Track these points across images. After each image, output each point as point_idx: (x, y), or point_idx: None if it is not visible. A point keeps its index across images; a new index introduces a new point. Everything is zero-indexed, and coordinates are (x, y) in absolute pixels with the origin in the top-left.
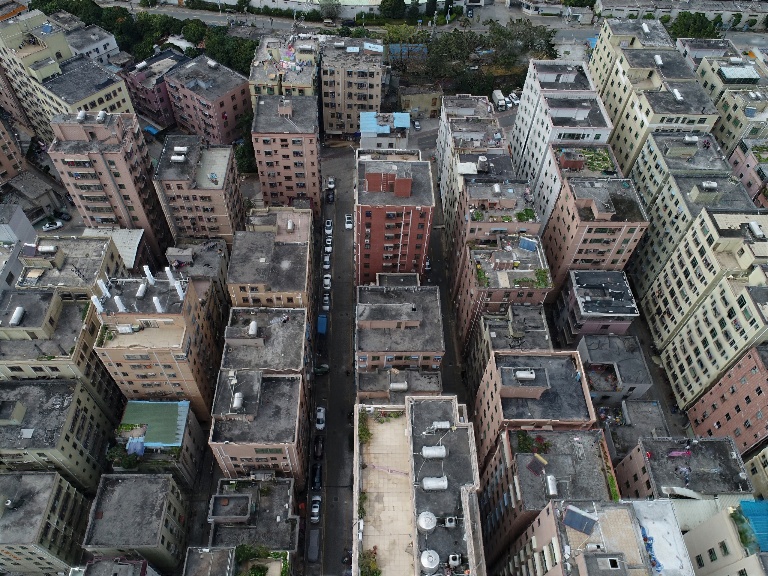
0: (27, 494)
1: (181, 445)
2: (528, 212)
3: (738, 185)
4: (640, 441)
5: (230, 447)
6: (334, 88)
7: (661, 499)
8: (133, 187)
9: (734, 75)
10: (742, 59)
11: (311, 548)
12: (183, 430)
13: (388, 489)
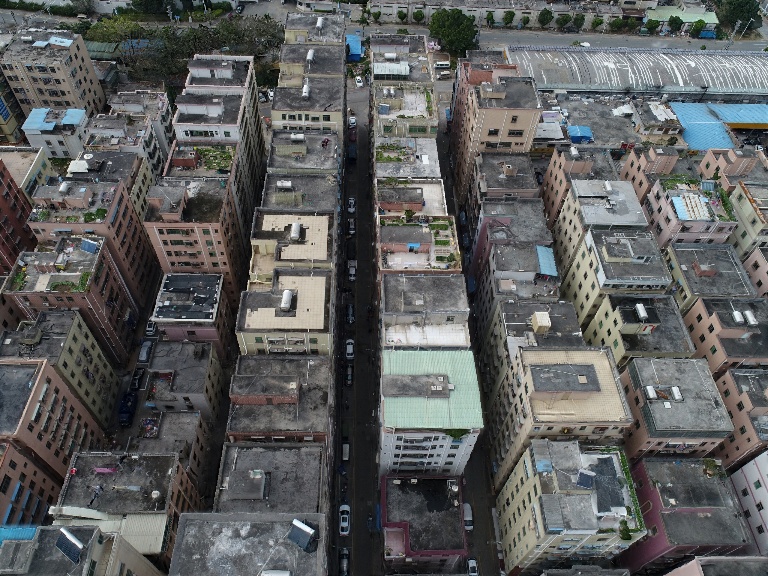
0: None
1: None
2: (99, 212)
3: (336, 185)
4: (72, 456)
5: None
6: (20, 84)
7: (61, 519)
8: None
9: (382, 71)
10: (412, 55)
11: None
12: None
13: None
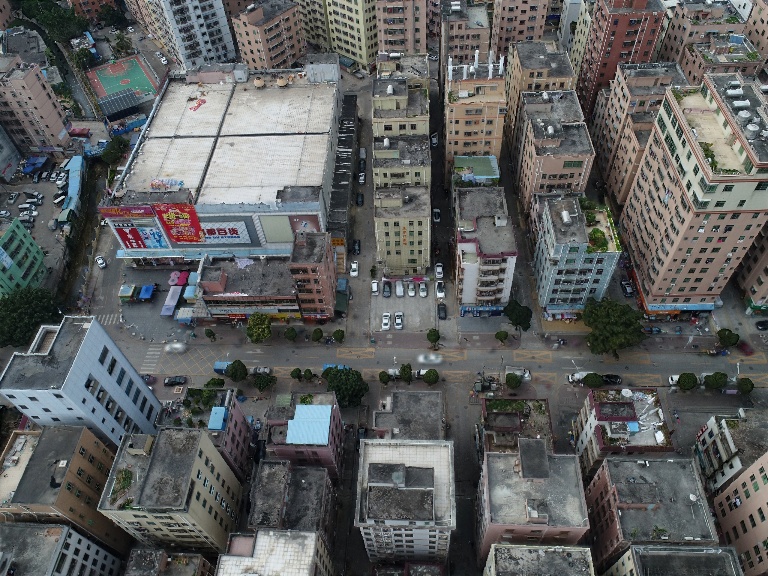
0: (413, 196)
1: (499, 177)
2: (733, 19)
3: None
4: None
5: (548, 160)
6: None
7: None
8: (425, 30)
9: None
10: None
11: None
12: (498, 170)
13: (702, 122)
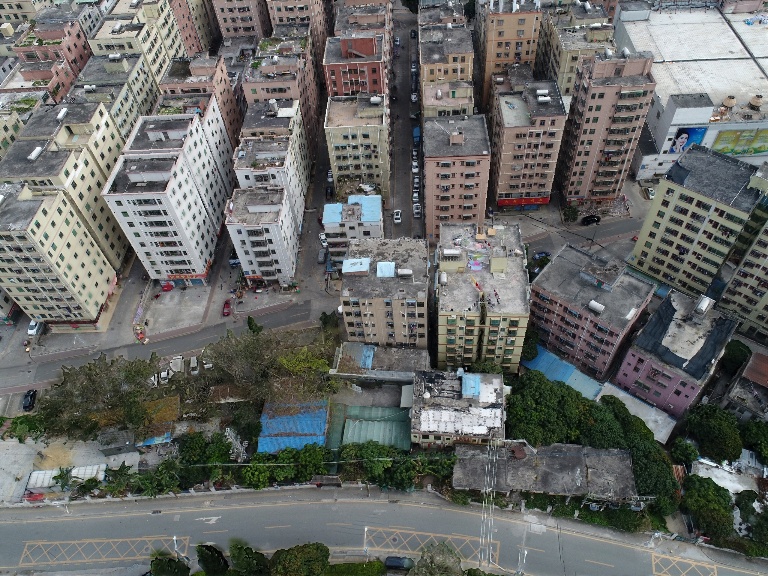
0: None
1: None
2: (256, 65)
3: None
4: None
5: None
6: None
7: None
8: None
9: None
10: None
11: (415, 55)
12: None
13: None
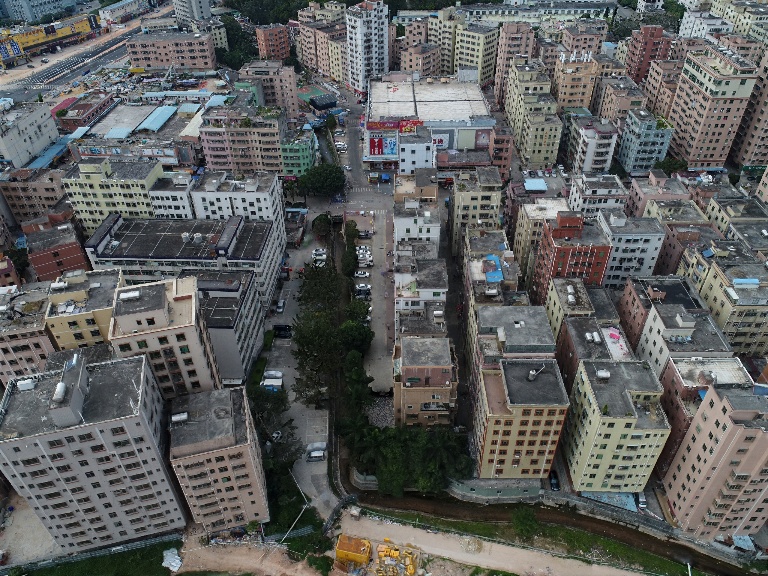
0: None
1: None
2: None
3: None
4: None
5: (623, 100)
6: None
7: None
8: None
9: None
10: None
11: None
12: None
13: None
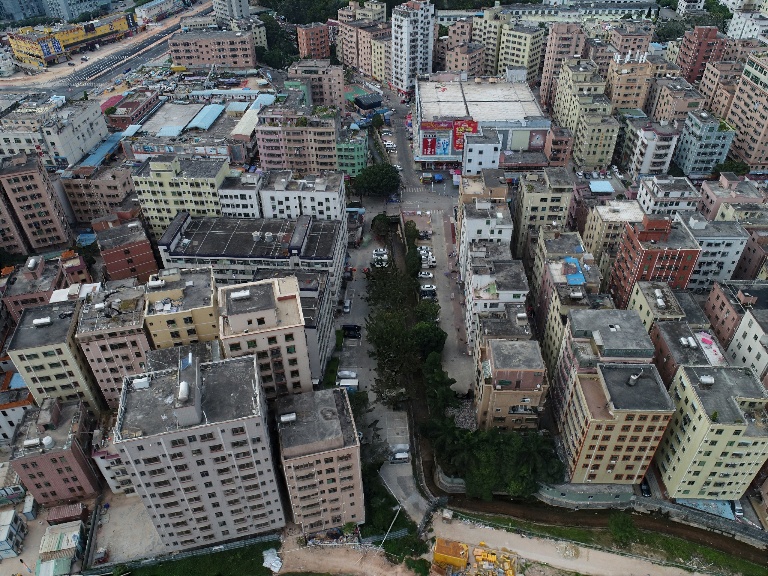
0: None
1: None
2: None
3: None
4: None
5: (680, 102)
6: None
7: None
8: None
9: None
10: None
11: None
12: None
13: None
